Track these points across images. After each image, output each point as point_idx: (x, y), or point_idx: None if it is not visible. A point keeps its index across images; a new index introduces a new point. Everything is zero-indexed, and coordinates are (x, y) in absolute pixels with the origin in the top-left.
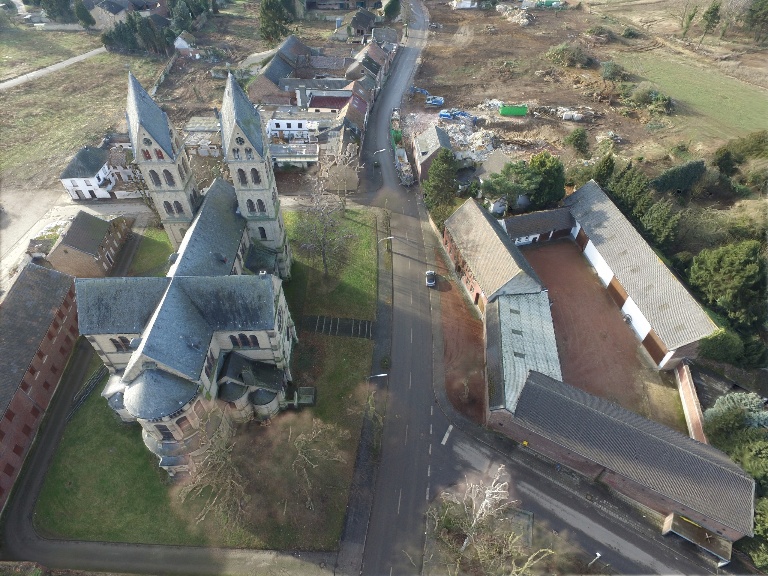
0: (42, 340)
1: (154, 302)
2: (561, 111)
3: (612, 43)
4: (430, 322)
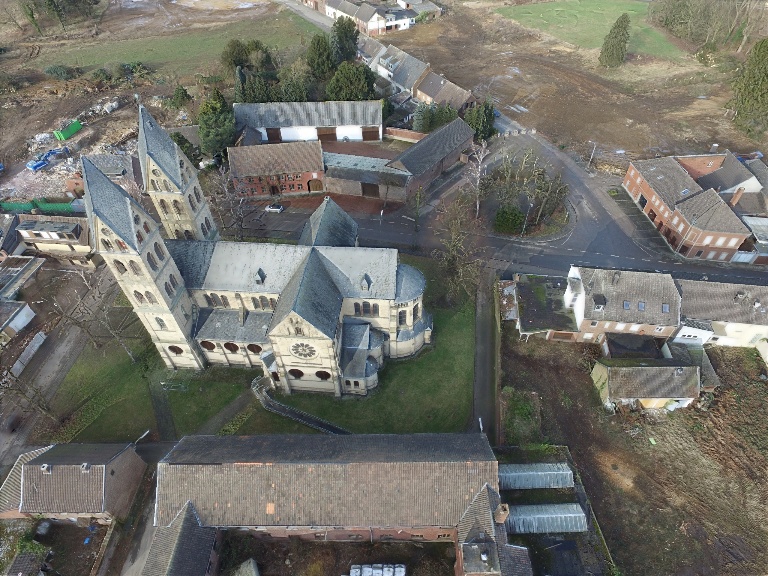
0: (289, 435)
1: (325, 272)
2: (98, 109)
3: (0, 62)
4: None
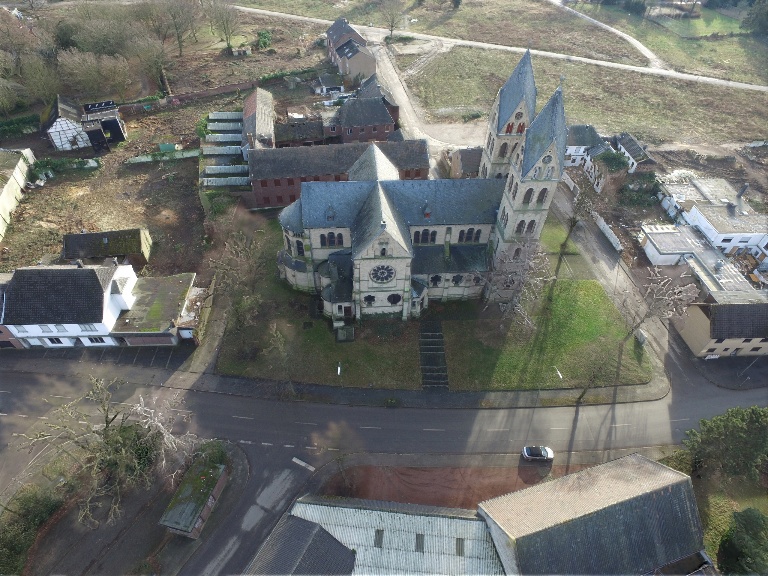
0: None
1: None
2: None
3: None
4: (460, 452)
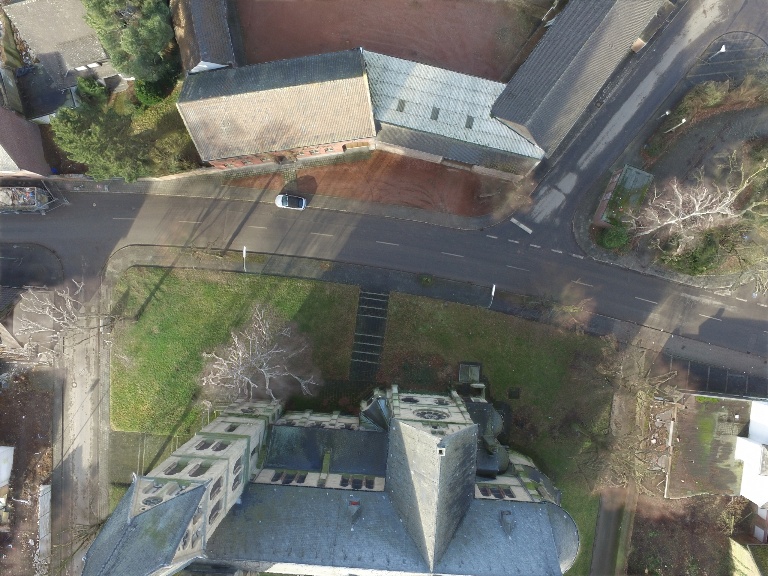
0: None
1: None
2: None
3: None
4: (368, 217)
